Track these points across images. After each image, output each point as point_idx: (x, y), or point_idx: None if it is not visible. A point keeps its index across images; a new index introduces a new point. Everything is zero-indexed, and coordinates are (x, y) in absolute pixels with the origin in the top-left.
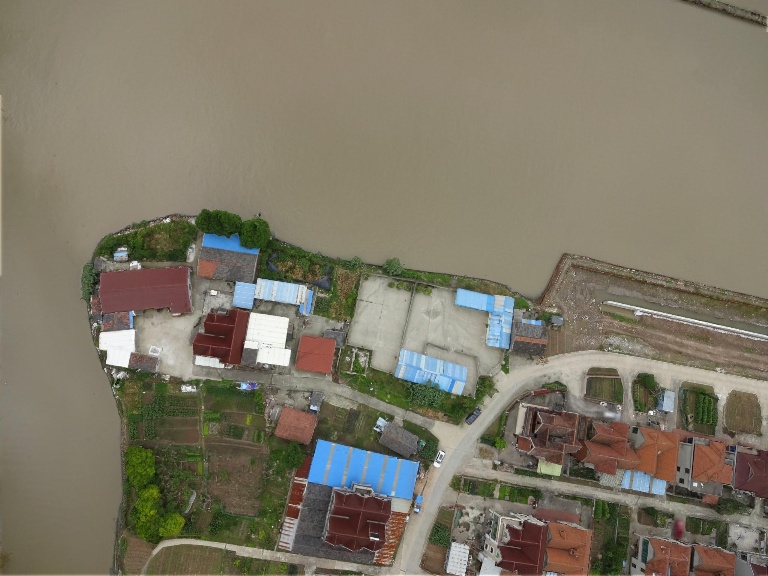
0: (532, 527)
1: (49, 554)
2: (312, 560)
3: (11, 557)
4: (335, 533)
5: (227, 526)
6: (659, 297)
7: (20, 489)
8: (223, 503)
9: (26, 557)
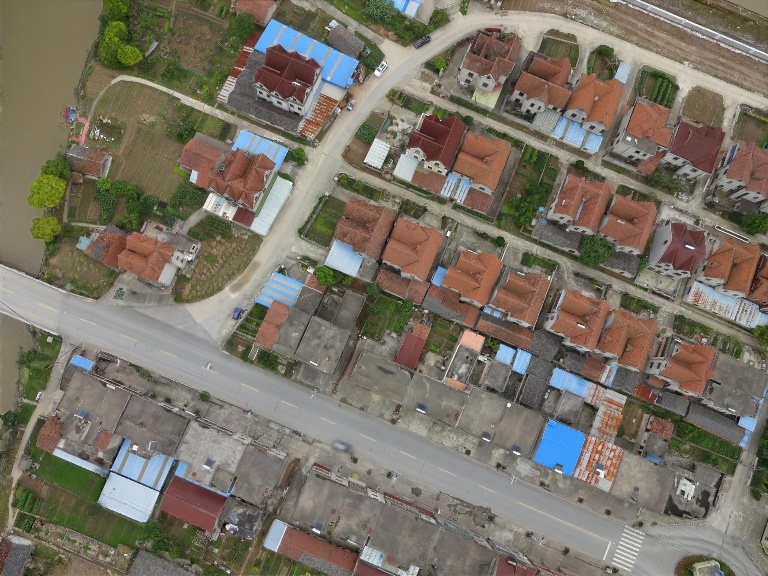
0: (448, 119)
1: (34, 88)
2: (245, 124)
3: (7, 98)
4: (262, 70)
5: (177, 74)
6: None
7: (24, 39)
8: (179, 59)
9: (17, 95)
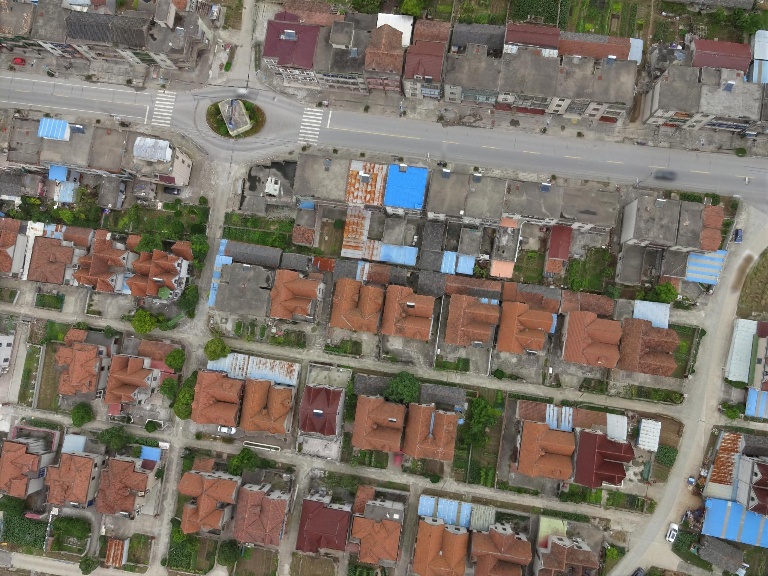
0: None
1: None
2: None
3: None
4: None
5: None
6: None
7: None
8: None
9: None
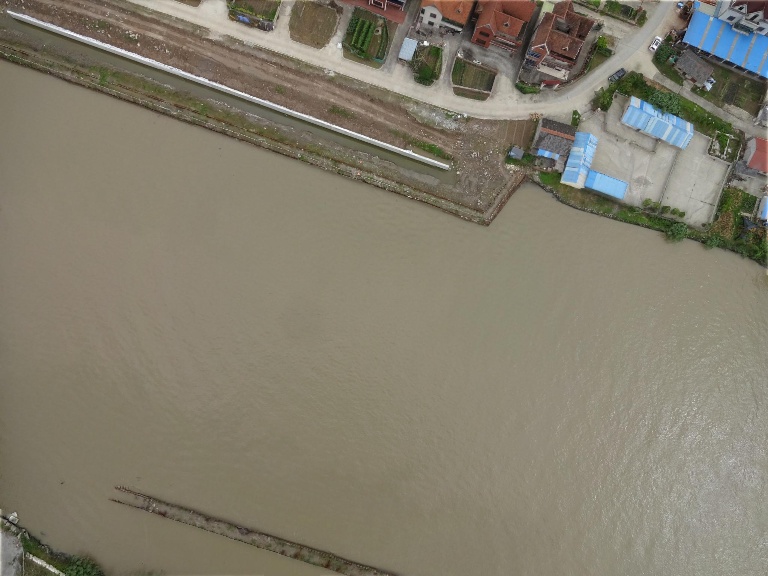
0: None
1: None
2: None
3: None
4: None
5: None
6: (379, 166)
7: None
8: None
9: None
